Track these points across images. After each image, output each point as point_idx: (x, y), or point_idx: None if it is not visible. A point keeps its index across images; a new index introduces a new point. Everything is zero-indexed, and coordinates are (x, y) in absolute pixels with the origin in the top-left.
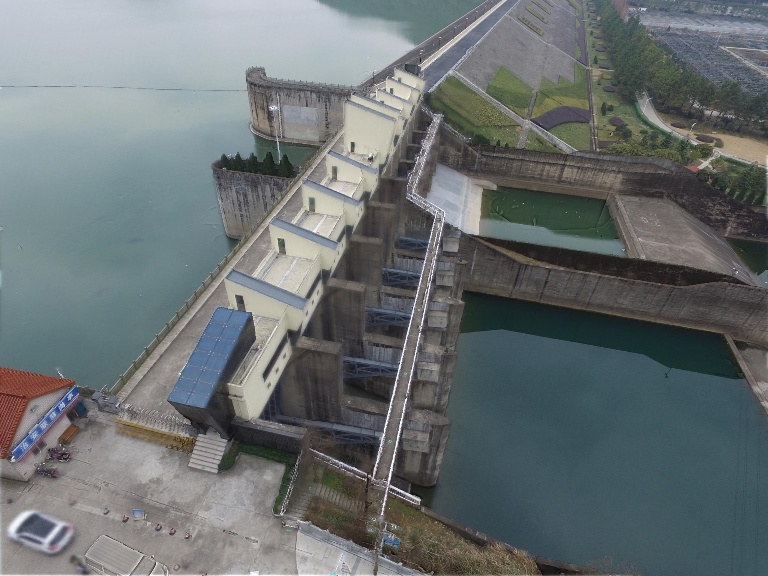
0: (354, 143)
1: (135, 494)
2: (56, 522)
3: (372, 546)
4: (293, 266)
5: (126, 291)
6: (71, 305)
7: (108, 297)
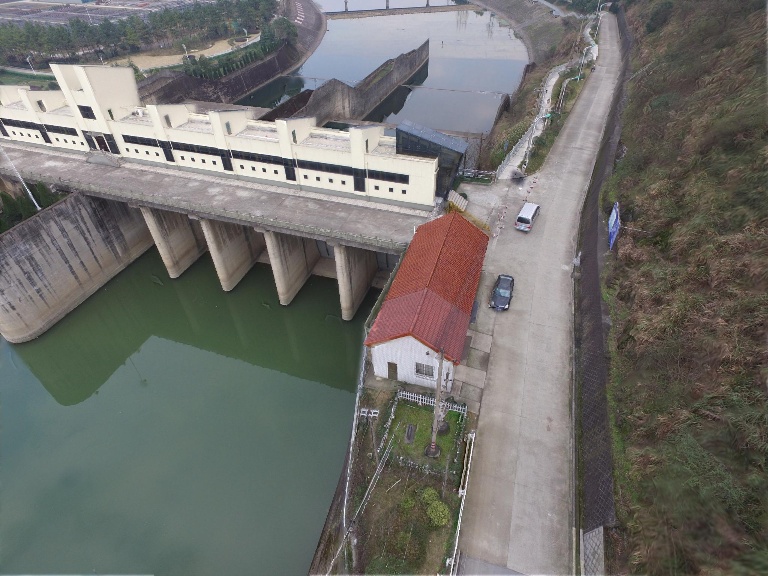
0: (110, 110)
1: (483, 228)
2: (505, 252)
3: (503, 160)
4: (313, 143)
5: (95, 436)
6: (83, 509)
7: (95, 458)
